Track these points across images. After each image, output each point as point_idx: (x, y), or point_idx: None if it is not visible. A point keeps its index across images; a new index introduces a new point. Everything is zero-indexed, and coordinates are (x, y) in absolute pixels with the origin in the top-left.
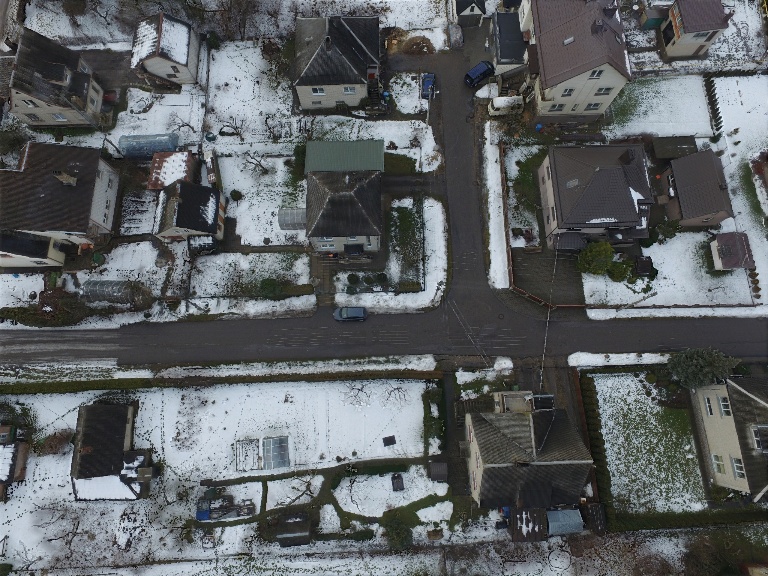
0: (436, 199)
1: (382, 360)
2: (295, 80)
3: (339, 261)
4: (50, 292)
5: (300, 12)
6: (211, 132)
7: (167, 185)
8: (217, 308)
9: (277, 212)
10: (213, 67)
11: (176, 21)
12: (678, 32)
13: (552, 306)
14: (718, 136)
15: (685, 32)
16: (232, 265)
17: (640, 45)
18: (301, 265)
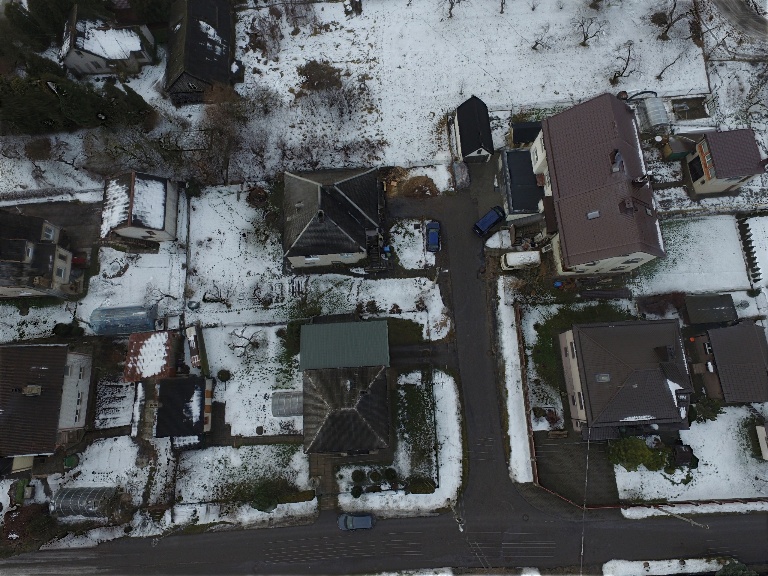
0: (447, 373)
1: (394, 575)
2: (285, 250)
3: (341, 453)
4: (16, 515)
5: (288, 149)
6: (194, 301)
7: (145, 377)
8: (206, 516)
9: (270, 394)
10: (194, 219)
11: (150, 179)
12: (708, 173)
13: (583, 509)
14: (757, 292)
15: (717, 178)
16: (222, 462)
17: (664, 180)
18: (299, 460)
